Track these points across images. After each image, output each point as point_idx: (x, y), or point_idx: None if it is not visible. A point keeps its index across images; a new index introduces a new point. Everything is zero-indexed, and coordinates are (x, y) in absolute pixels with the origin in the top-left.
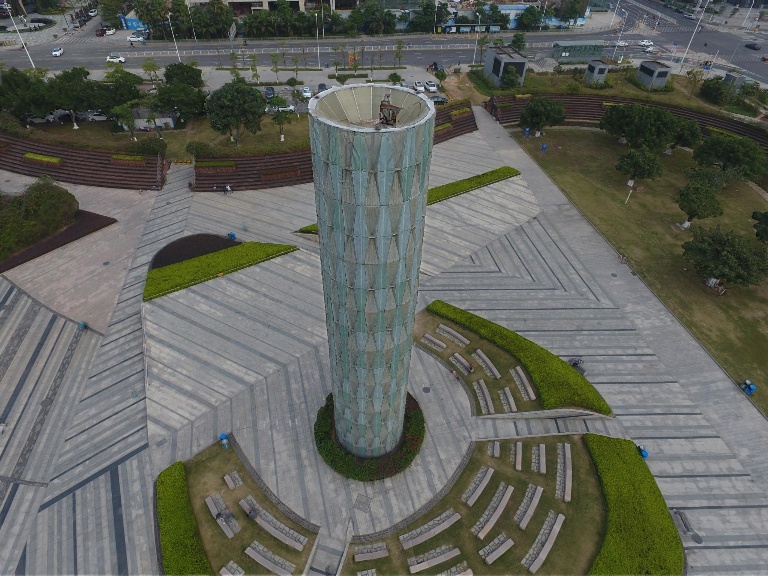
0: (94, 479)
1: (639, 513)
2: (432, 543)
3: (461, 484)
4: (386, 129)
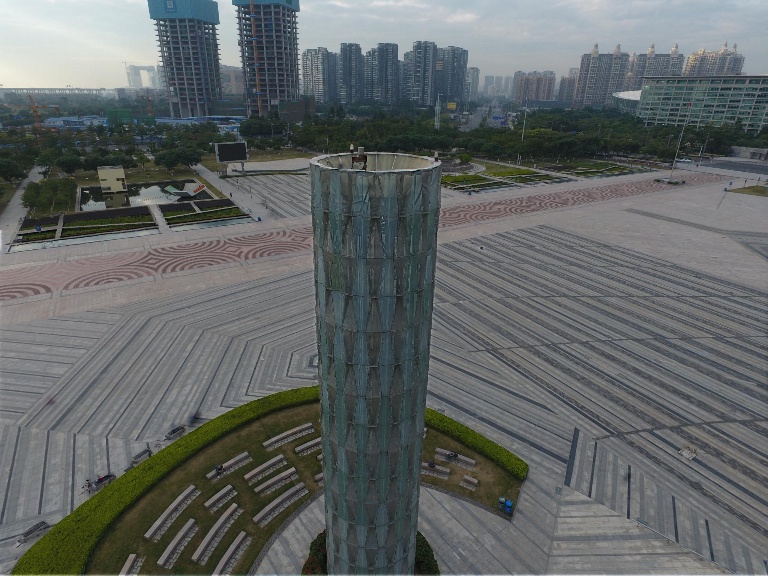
0: (570, 452)
1: (50, 568)
2: (279, 493)
3: (252, 554)
4: (346, 153)
